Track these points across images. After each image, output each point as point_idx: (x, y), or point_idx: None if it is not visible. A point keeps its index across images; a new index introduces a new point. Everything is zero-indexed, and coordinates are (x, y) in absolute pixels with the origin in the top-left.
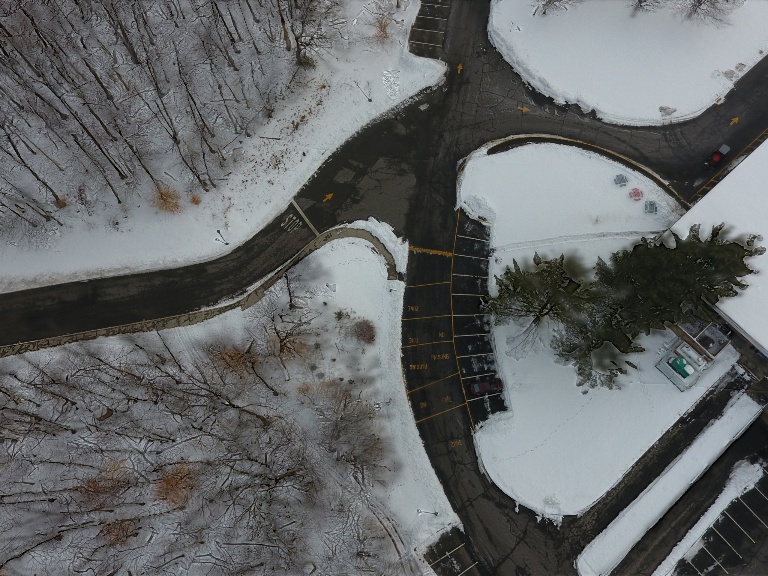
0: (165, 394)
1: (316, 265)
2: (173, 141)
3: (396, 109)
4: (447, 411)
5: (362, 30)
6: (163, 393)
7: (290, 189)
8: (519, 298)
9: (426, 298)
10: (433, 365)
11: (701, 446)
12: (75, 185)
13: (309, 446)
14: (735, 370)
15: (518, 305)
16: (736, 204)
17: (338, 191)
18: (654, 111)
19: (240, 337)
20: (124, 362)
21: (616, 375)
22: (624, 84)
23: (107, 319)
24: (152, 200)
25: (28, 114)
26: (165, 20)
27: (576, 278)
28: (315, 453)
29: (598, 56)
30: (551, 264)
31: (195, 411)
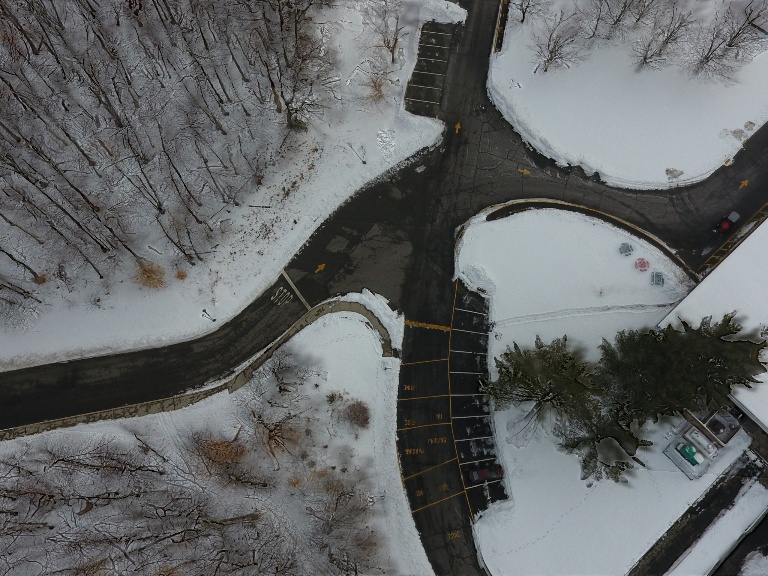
0: (148, 486)
1: (307, 343)
2: (158, 211)
3: (391, 172)
4: (444, 500)
5: (356, 90)
6: (146, 485)
7: (280, 259)
8: (520, 384)
9: (423, 376)
10: (430, 449)
11: (711, 539)
12: (54, 261)
13: (299, 541)
14: (747, 455)
15: (519, 391)
16: (747, 279)
17: (331, 261)
18: (660, 174)
19: (227, 423)
20: (105, 451)
21: (622, 469)
22: (629, 144)
23: (87, 404)
24: (135, 276)
25: (6, 184)
26: (150, 80)
27: (580, 358)
28: (306, 549)
29: (602, 114)
30: (553, 345)
31: (179, 505)
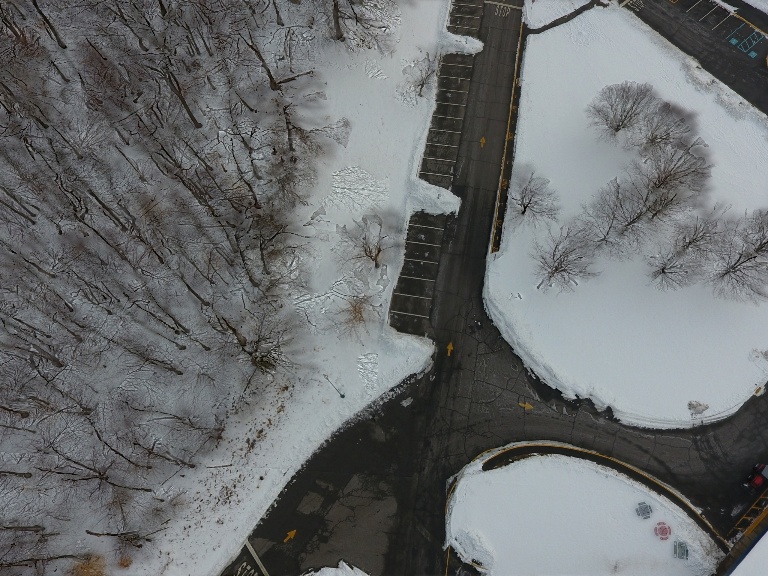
0: None
1: None
2: (99, 480)
3: (374, 406)
4: None
5: (332, 316)
6: None
7: (244, 527)
8: None
9: None
10: None
11: None
12: None
13: None
14: None
15: None
16: None
17: (302, 526)
18: (682, 408)
19: None
20: None
21: None
22: (645, 371)
23: None
24: (70, 571)
25: None
26: (95, 306)
27: None
28: None
29: (614, 332)
30: None
31: None
